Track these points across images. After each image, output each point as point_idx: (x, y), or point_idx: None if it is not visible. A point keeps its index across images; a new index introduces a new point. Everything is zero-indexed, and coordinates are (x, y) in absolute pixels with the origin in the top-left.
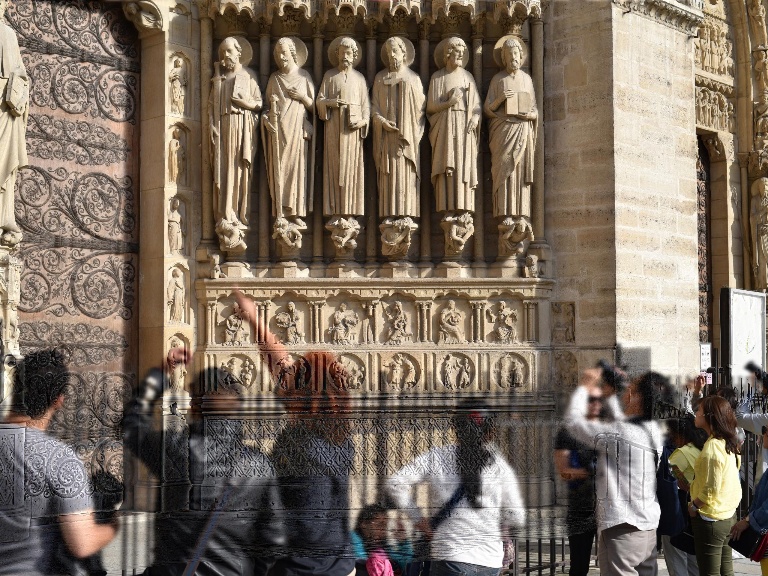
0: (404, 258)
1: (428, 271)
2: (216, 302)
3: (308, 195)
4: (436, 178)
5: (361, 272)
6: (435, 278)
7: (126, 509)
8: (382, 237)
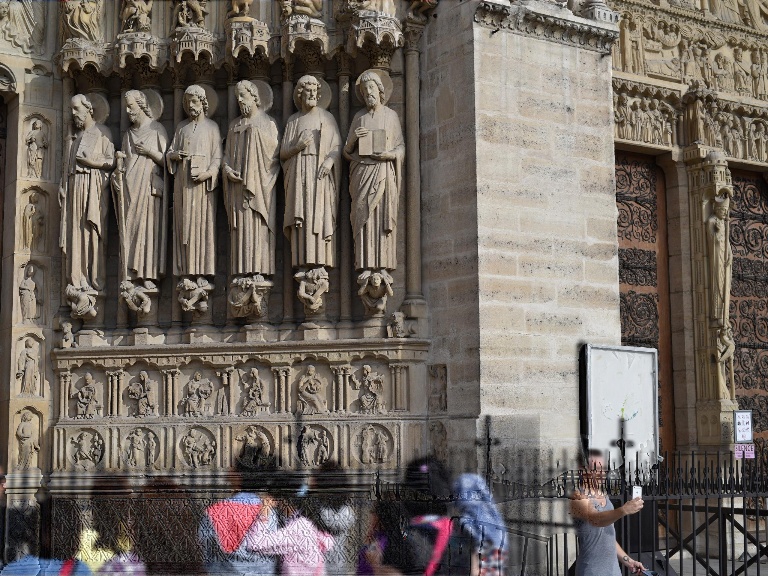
0: (260, 320)
1: (288, 334)
2: (69, 373)
3: (159, 256)
4: (290, 230)
5: (217, 337)
6: (289, 341)
7: None
8: (228, 298)
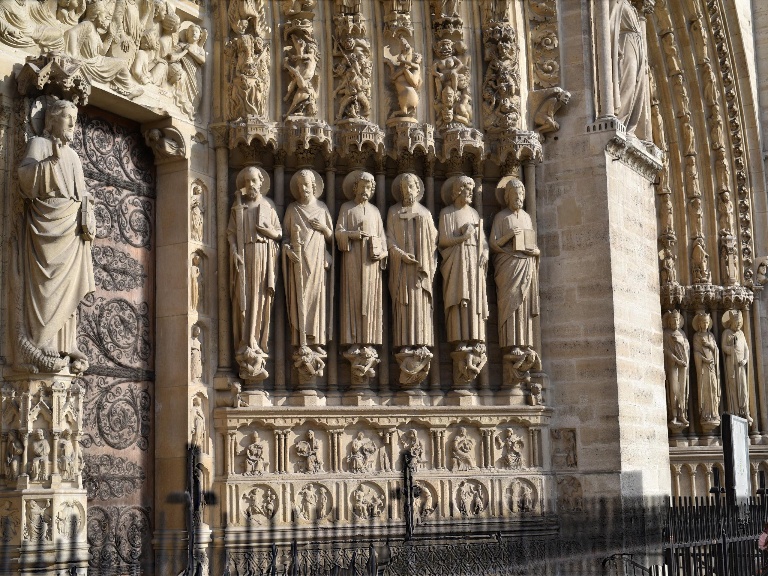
0: (418, 386)
1: (440, 399)
2: (236, 431)
3: (327, 324)
4: (449, 309)
5: (377, 400)
6: (450, 406)
7: None
8: (402, 366)
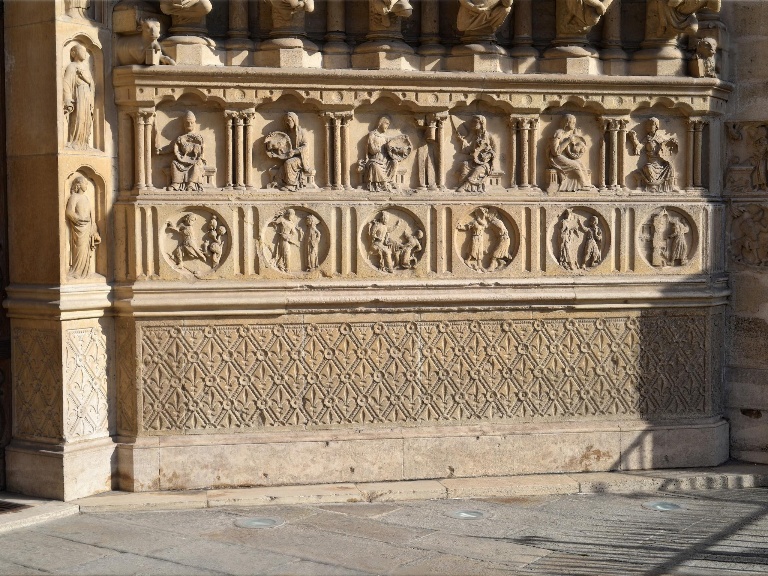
0: (491, 38)
1: (530, 62)
2: (153, 110)
3: None
4: None
5: (414, 61)
6: (547, 74)
7: None
8: None
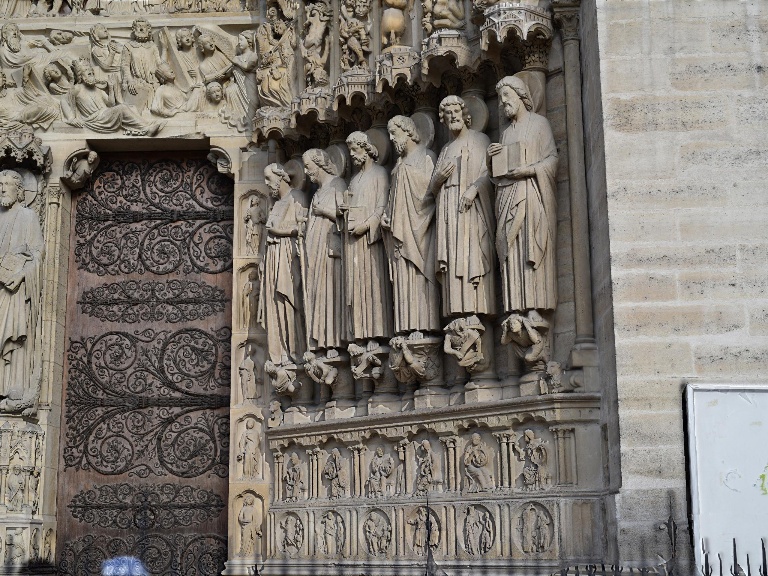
0: (429, 384)
1: (456, 397)
2: (280, 454)
3: None
4: None
5: (396, 406)
6: (449, 406)
7: None
8: None
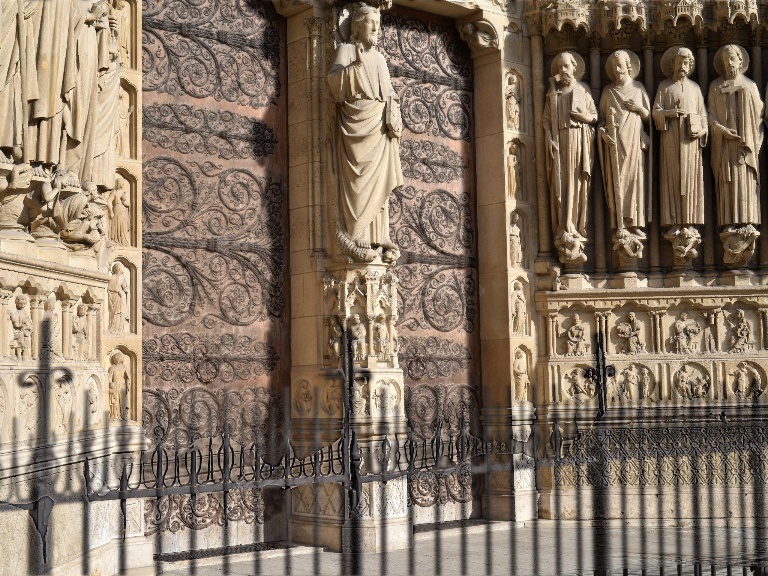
0: (745, 266)
1: None
2: (557, 314)
3: (646, 206)
4: None
5: (701, 281)
6: None
7: (476, 518)
8: (725, 245)
